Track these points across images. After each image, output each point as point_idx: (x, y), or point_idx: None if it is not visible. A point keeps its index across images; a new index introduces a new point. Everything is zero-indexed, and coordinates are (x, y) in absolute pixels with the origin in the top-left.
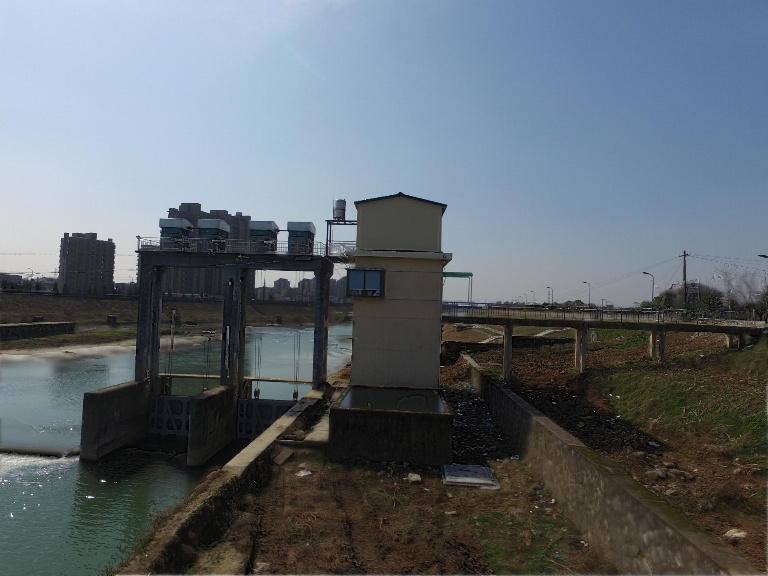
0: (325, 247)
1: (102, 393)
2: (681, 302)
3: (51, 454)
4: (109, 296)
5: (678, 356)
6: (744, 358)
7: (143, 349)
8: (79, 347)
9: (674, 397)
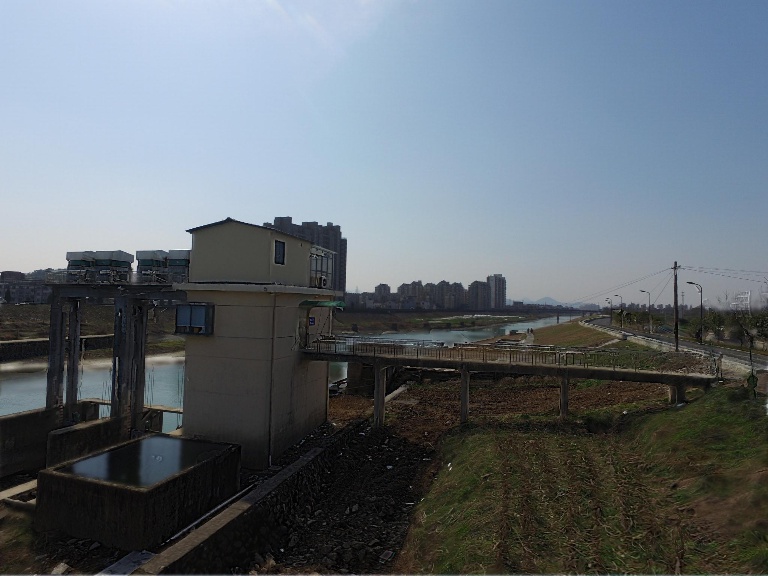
0: None
1: None
2: (733, 321)
3: None
4: None
5: (594, 410)
6: (652, 424)
7: (52, 377)
8: None
9: (465, 485)
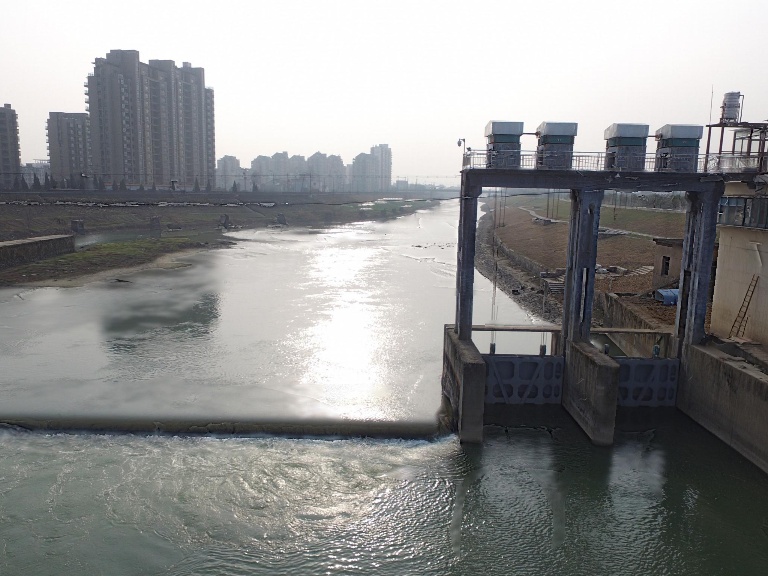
0: (717, 160)
1: None
2: None
3: (414, 437)
4: (56, 191)
5: None
6: None
7: None
8: (119, 272)
9: None
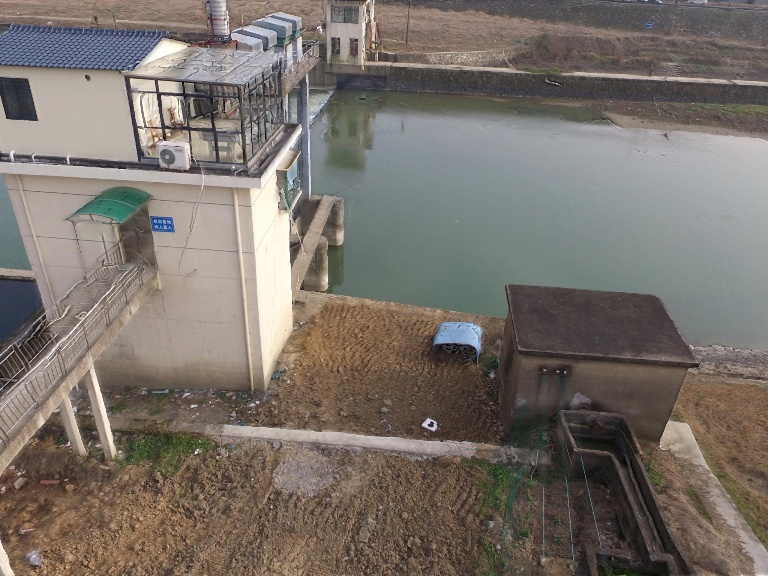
0: None
1: None
2: None
3: None
4: None
5: None
6: None
7: None
8: (711, 131)
9: None
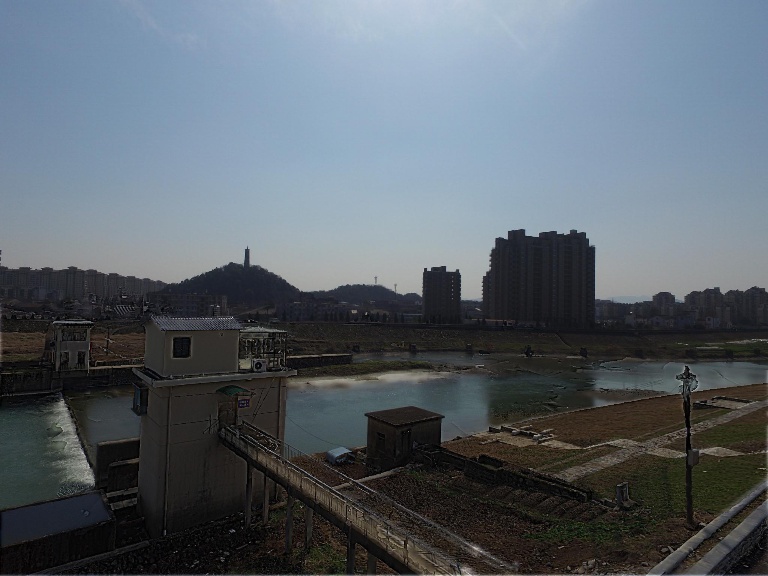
0: None
1: (101, 445)
2: None
3: None
4: (423, 325)
5: None
6: None
7: None
8: (326, 378)
9: None
